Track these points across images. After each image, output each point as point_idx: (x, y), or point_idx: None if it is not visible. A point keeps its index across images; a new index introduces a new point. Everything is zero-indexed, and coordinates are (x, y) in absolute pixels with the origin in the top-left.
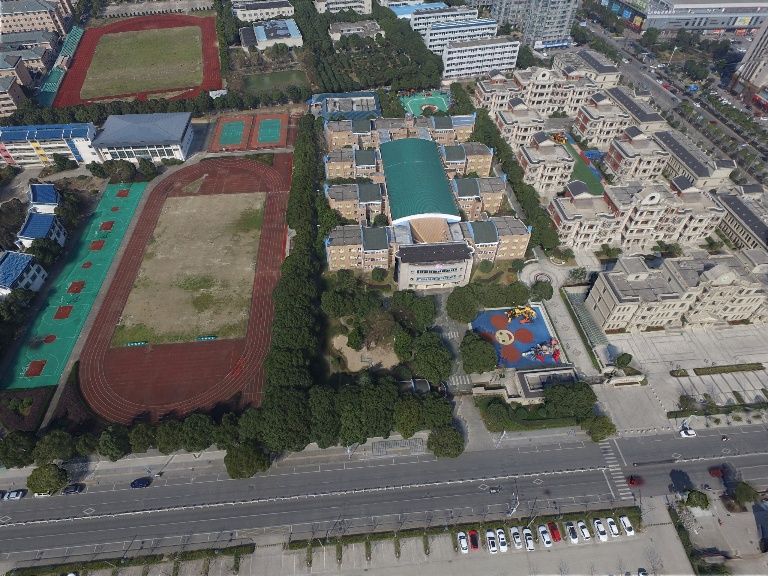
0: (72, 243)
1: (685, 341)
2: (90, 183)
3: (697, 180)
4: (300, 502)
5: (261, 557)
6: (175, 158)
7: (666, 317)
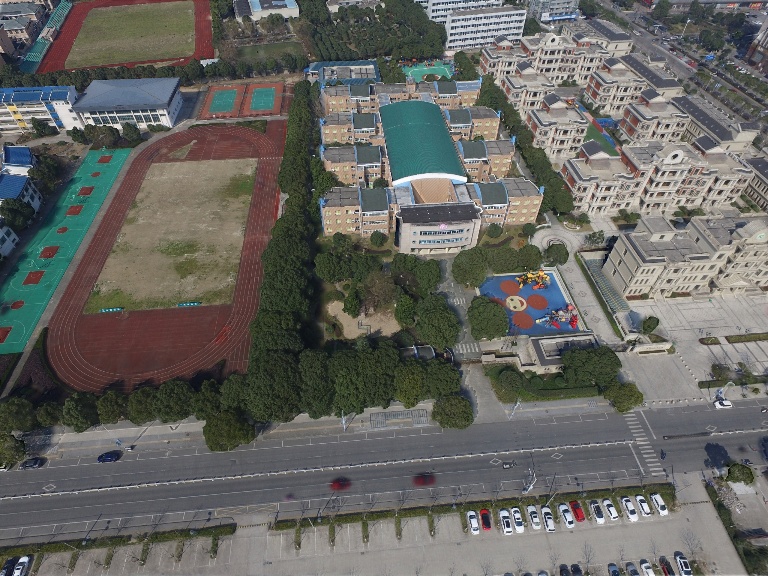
0: (48, 208)
1: (714, 308)
2: (70, 149)
3: (719, 144)
4: (288, 478)
5: (243, 538)
6: (162, 124)
7: (693, 281)
